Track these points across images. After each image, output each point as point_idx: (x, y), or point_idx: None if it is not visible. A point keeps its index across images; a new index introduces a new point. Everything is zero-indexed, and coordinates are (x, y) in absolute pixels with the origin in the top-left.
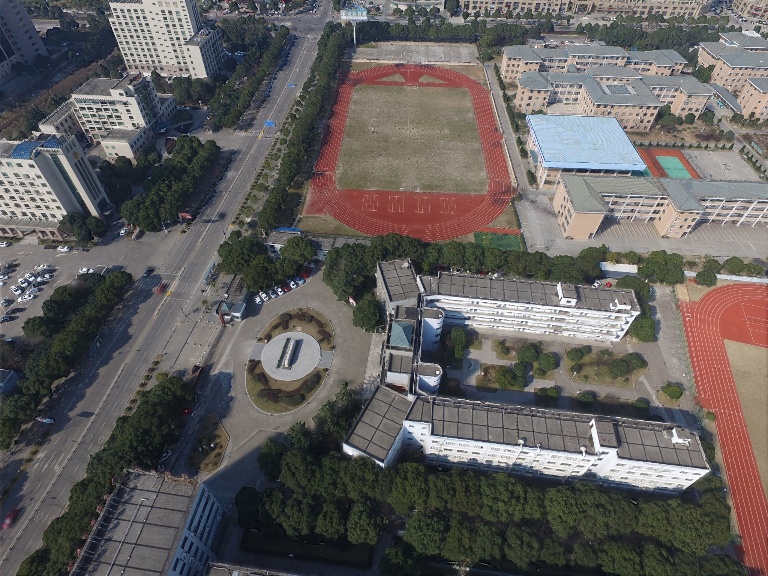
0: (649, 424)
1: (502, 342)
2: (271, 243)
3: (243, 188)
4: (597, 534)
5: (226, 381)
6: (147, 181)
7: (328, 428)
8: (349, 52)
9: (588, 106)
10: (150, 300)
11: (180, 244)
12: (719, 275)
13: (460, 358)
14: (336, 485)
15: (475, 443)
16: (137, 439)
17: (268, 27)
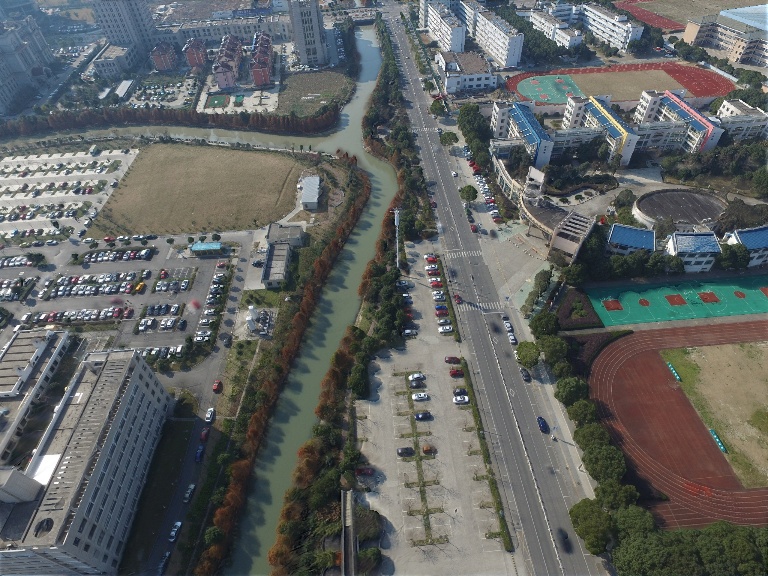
0: None
1: None
2: None
3: None
4: None
5: None
6: None
7: None
8: None
9: None
10: None
11: None
12: (712, 66)
13: None
14: None
15: None
16: None
17: None
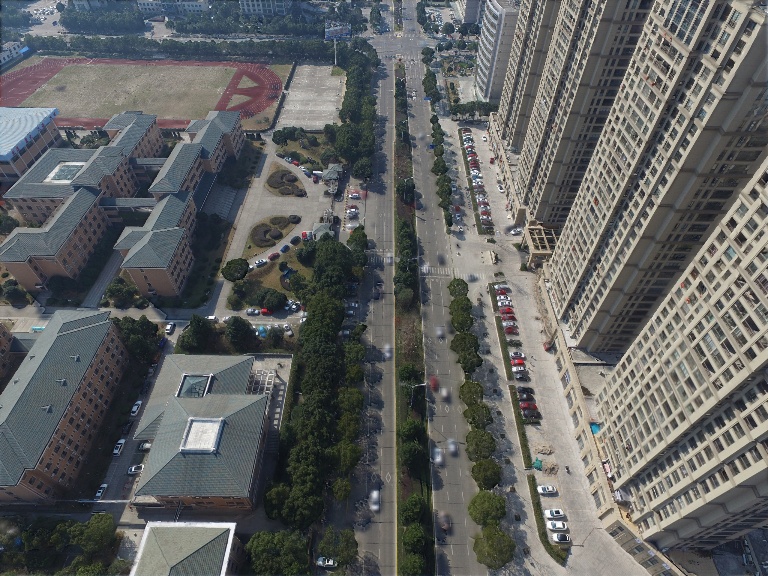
0: None
1: None
2: None
3: None
4: None
5: None
6: None
7: None
8: (319, 63)
9: None
10: None
11: (49, 33)
12: None
13: None
14: None
15: None
16: None
17: None
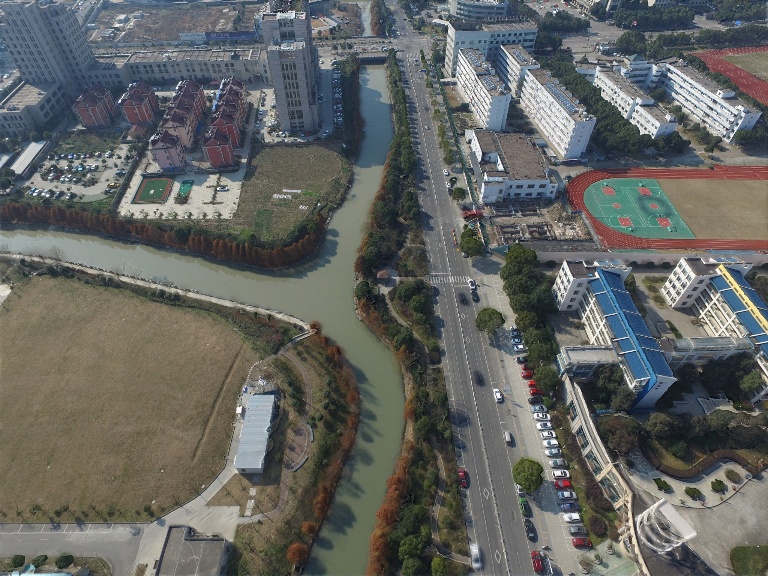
0: None
1: None
2: (649, 42)
3: None
4: None
5: None
6: (640, 8)
7: None
8: None
9: None
10: (585, 37)
11: (620, 34)
12: None
13: None
14: None
15: None
16: (536, 36)
17: None
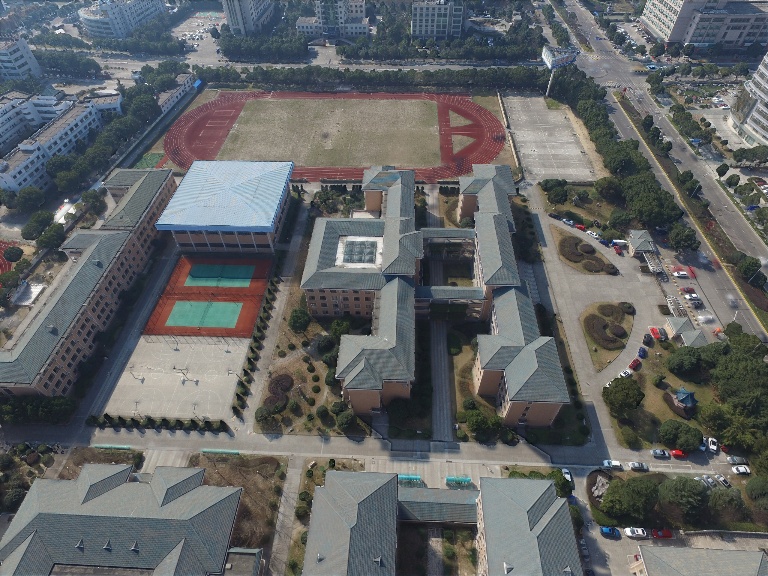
0: None
1: None
2: (179, 75)
3: None
4: None
5: (99, 84)
6: None
7: None
8: (526, 93)
9: None
10: None
11: (209, 62)
12: None
13: None
14: None
15: None
16: (62, 56)
17: None
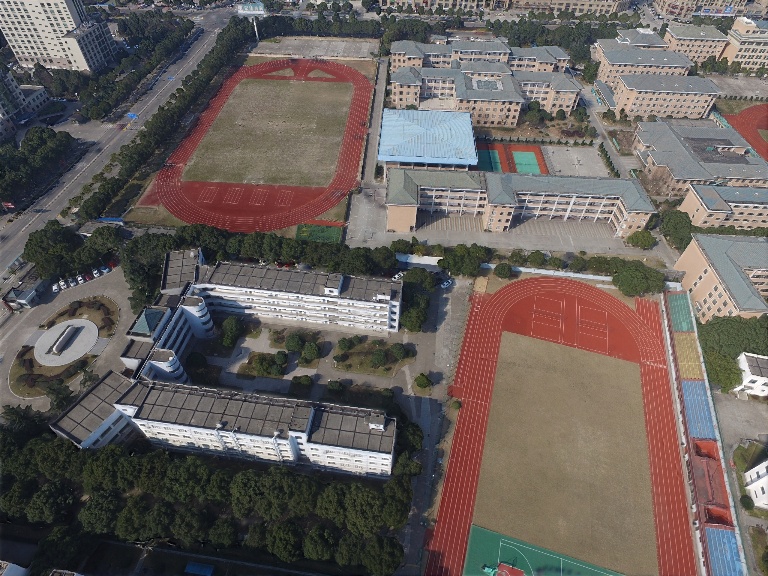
0: (355, 410)
1: (281, 331)
2: (82, 232)
3: (87, 179)
4: (272, 516)
5: None
6: None
7: (55, 411)
8: (250, 46)
9: (455, 101)
10: None
11: (2, 233)
12: (523, 268)
13: (229, 346)
14: (28, 465)
15: (174, 426)
16: None
17: (176, 21)
